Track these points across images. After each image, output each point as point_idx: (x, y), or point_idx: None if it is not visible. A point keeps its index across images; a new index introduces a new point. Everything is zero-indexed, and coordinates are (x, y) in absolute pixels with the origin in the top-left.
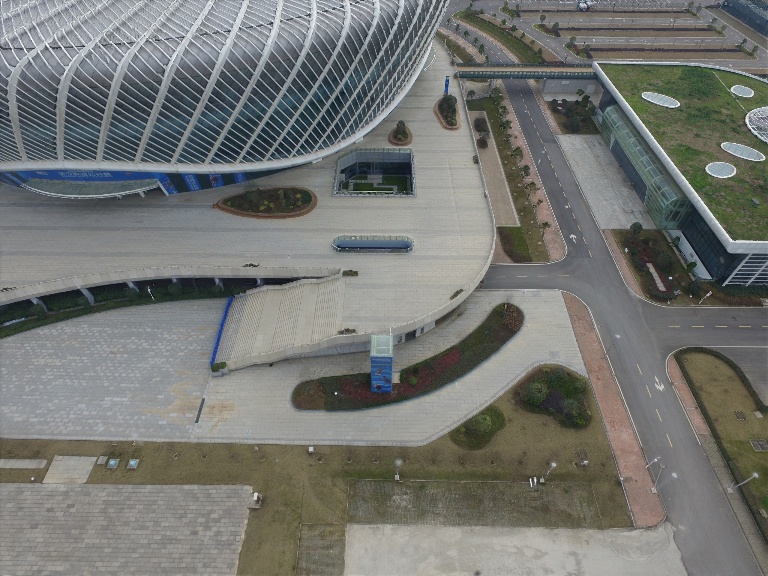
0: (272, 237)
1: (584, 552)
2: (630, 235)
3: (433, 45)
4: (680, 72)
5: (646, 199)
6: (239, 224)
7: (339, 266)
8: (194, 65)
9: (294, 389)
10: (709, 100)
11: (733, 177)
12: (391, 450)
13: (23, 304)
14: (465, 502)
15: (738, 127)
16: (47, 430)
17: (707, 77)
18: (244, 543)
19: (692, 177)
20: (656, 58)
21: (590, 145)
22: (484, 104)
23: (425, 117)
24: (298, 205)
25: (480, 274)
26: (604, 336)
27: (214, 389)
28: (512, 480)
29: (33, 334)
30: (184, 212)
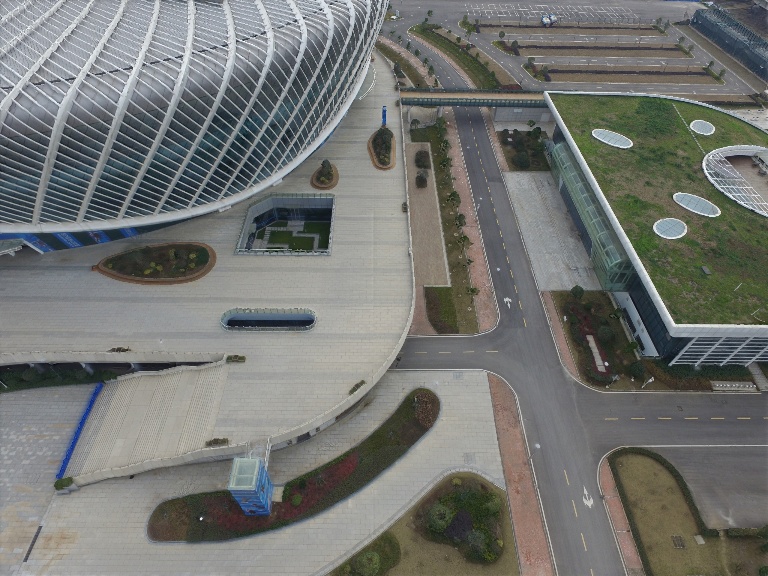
0: (154, 309)
1: None
2: (571, 298)
3: (379, 66)
4: (637, 104)
5: (592, 254)
6: (118, 292)
7: (225, 349)
8: (26, 121)
9: (153, 511)
10: (665, 139)
11: (683, 238)
12: None
13: None
14: None
15: (694, 173)
16: None
17: (666, 110)
18: None
19: (637, 238)
20: (618, 82)
21: (538, 185)
22: (429, 134)
23: (357, 153)
24: (191, 268)
25: (387, 360)
26: (530, 432)
27: (56, 512)
28: None
29: None
30: (57, 276)
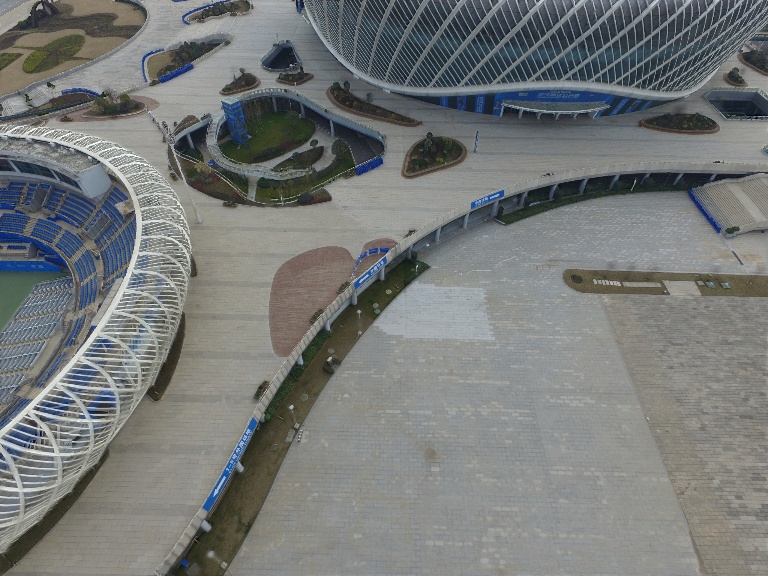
0: (709, 146)
1: None
2: None
3: None
4: None
5: None
6: (673, 137)
7: None
8: None
9: None
10: None
11: None
12: None
13: (534, 192)
14: None
15: None
16: (638, 267)
17: None
18: None
19: None
20: None
21: None
22: None
23: (740, 67)
24: (711, 125)
25: None
26: None
27: (734, 245)
28: None
29: (561, 211)
30: (620, 129)
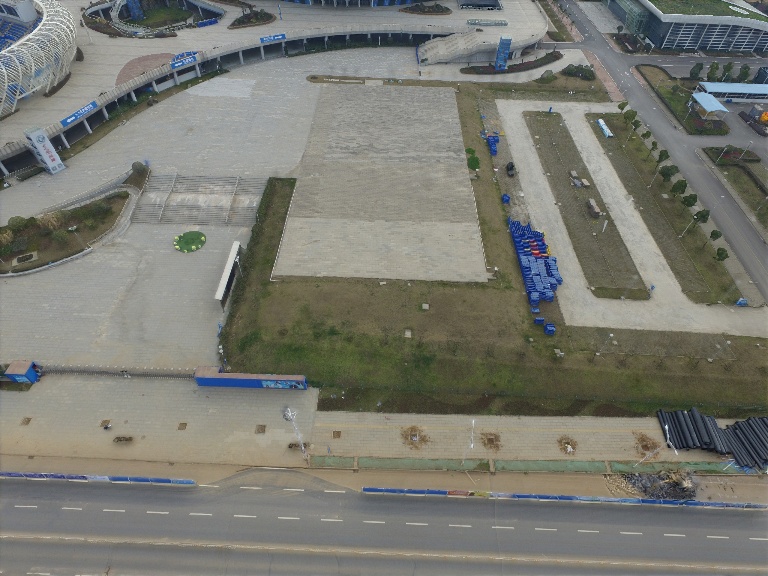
0: (435, 20)
1: (592, 106)
2: (617, 34)
3: None
4: None
5: (626, 21)
6: (416, 16)
7: None
8: None
9: (460, 69)
10: None
11: None
12: (509, 83)
13: (316, 44)
14: (542, 96)
15: None
16: (356, 75)
17: None
18: (456, 98)
19: None
20: None
21: (596, 6)
22: None
23: None
24: (444, 10)
25: (543, 31)
26: (602, 61)
27: (423, 69)
28: (562, 92)
29: (328, 53)
30: (385, 12)
